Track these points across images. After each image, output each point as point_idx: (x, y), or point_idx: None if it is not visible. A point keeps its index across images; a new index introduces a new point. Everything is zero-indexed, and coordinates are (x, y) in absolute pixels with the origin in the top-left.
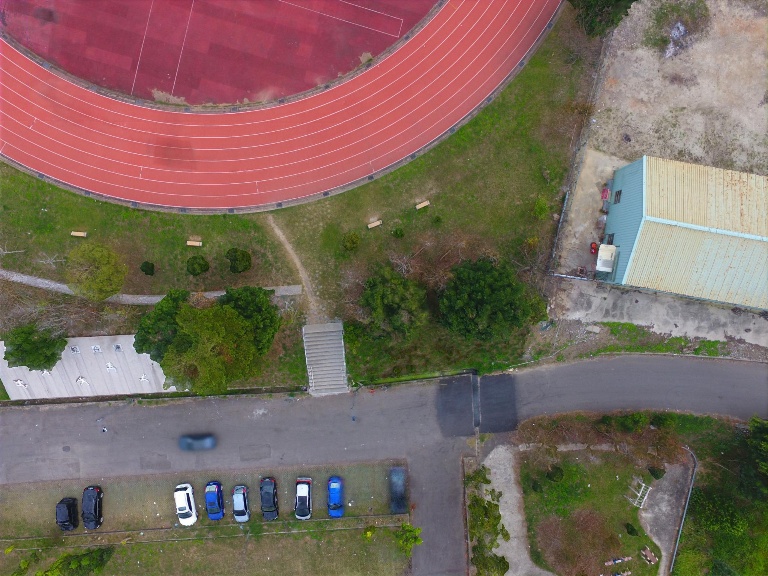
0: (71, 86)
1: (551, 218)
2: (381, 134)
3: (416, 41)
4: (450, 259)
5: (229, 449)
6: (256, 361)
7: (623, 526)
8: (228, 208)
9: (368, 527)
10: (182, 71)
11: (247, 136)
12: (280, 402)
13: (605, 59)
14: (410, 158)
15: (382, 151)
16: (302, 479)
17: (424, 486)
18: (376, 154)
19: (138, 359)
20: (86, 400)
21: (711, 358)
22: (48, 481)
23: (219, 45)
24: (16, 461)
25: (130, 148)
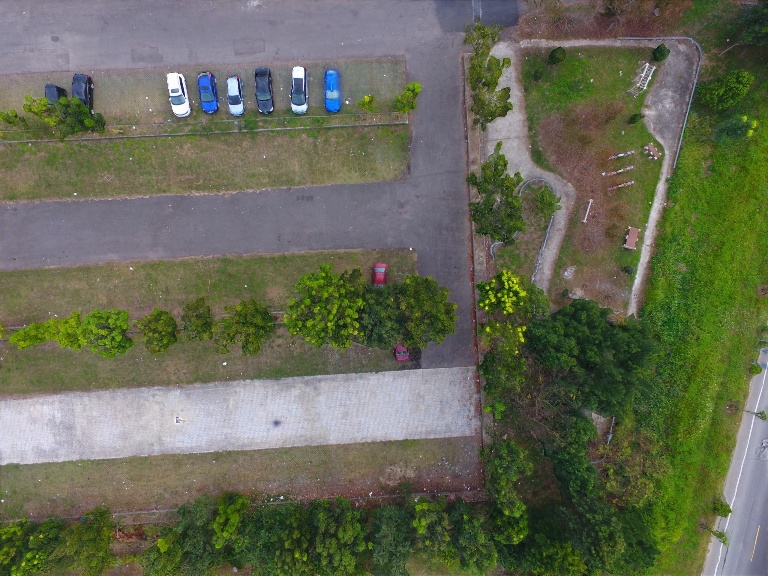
0: None
1: None
2: None
3: None
4: None
5: (223, 42)
6: None
7: (626, 124)
8: None
9: None
10: None
11: None
12: None
13: None
14: None
15: None
16: None
17: (423, 84)
18: None
19: None
20: None
21: None
22: (37, 73)
23: None
24: (3, 51)
25: None
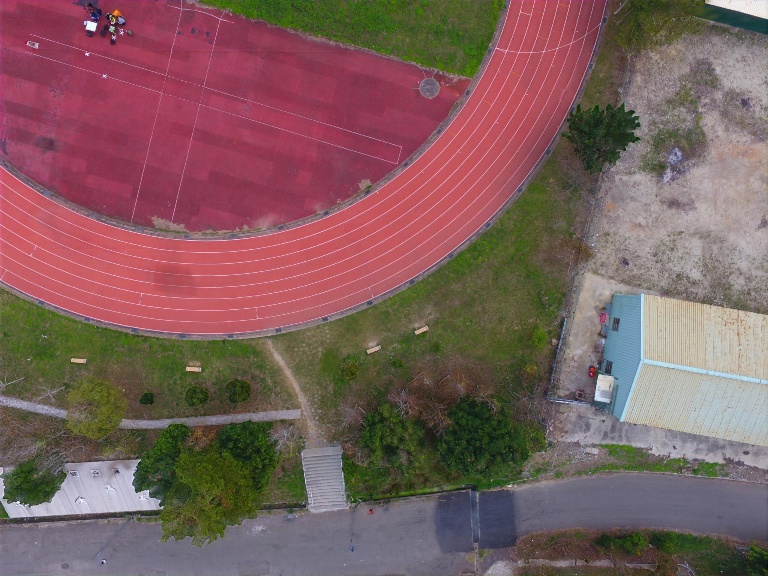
0: (71, 214)
1: (549, 343)
2: (380, 260)
3: (415, 168)
4: (449, 384)
5: (228, 566)
6: None
7: None
8: (227, 334)
9: None
10: (182, 198)
11: (246, 262)
12: (279, 518)
13: (603, 184)
14: (409, 283)
15: (381, 277)
16: None
17: None
18: (375, 280)
19: None
20: (85, 516)
21: (710, 478)
22: None
23: (219, 173)
24: None
25: (130, 275)
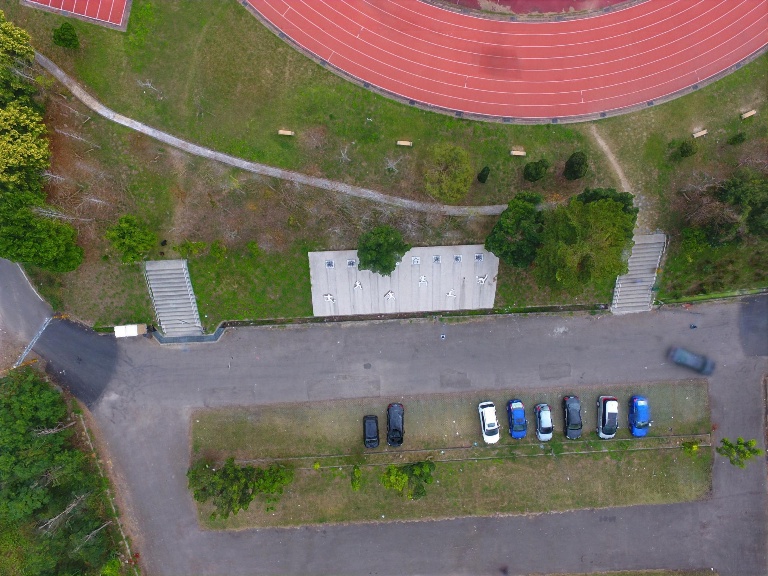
0: None
1: None
2: (707, 43)
3: None
4: None
5: (529, 367)
6: None
7: None
8: (552, 118)
9: (686, 443)
10: None
11: (572, 45)
12: (581, 320)
13: None
14: (735, 67)
15: (708, 60)
16: (608, 397)
17: (725, 406)
18: (701, 63)
19: (452, 272)
20: (384, 318)
21: None
22: (348, 399)
23: None
24: (317, 378)
25: (456, 57)
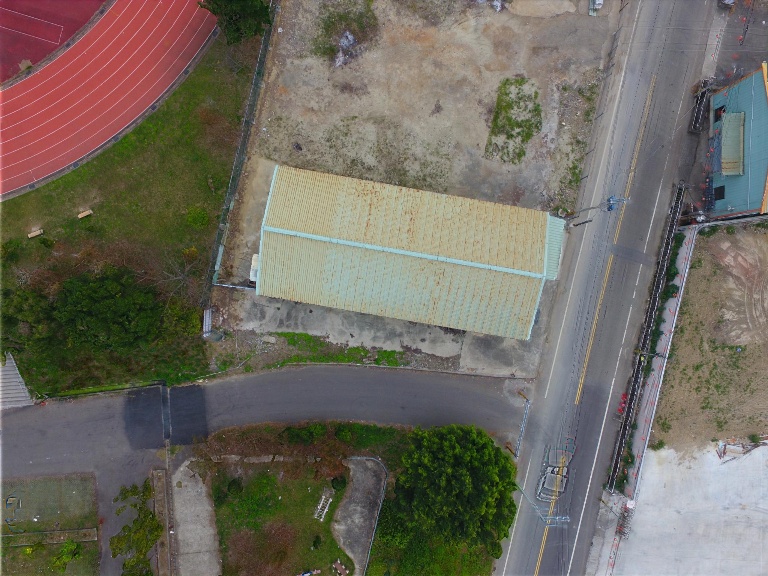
0: None
1: (218, 227)
2: (42, 142)
3: (77, 48)
4: None
5: None
6: None
7: None
8: None
9: None
10: None
11: None
12: None
13: (274, 67)
14: (73, 166)
15: (43, 159)
16: None
17: None
18: (37, 162)
19: None
20: None
21: (393, 368)
22: None
23: None
24: None
25: None
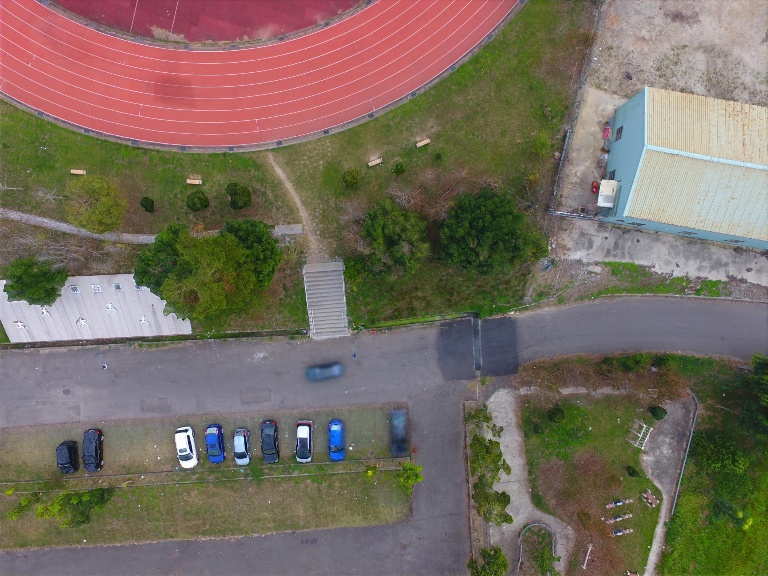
0: (70, 23)
1: (552, 156)
2: (381, 72)
3: None
4: None
5: (230, 392)
6: (256, 295)
7: (624, 469)
8: (228, 146)
9: None
10: (181, 8)
11: (247, 74)
12: (281, 345)
13: None
14: (410, 96)
15: (382, 89)
16: (303, 421)
17: (425, 430)
18: (376, 92)
19: (138, 300)
20: (86, 344)
21: (713, 299)
22: (48, 424)
23: None
24: (16, 404)
25: (129, 86)
